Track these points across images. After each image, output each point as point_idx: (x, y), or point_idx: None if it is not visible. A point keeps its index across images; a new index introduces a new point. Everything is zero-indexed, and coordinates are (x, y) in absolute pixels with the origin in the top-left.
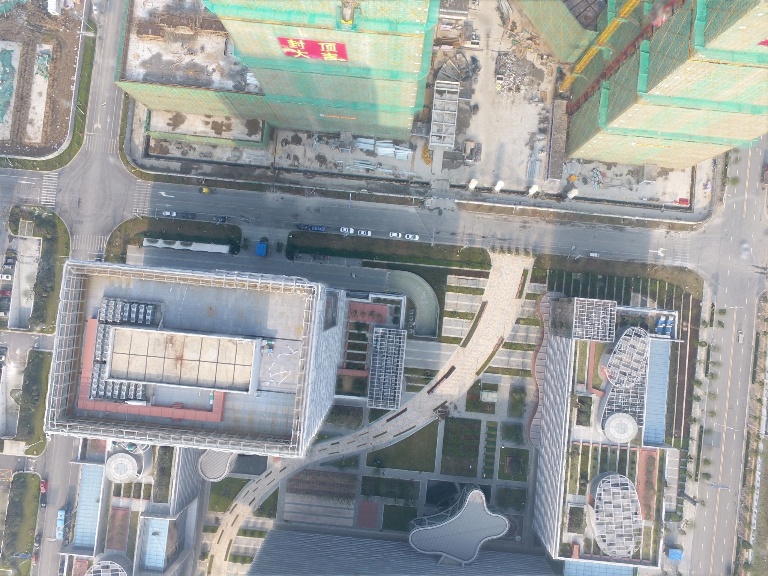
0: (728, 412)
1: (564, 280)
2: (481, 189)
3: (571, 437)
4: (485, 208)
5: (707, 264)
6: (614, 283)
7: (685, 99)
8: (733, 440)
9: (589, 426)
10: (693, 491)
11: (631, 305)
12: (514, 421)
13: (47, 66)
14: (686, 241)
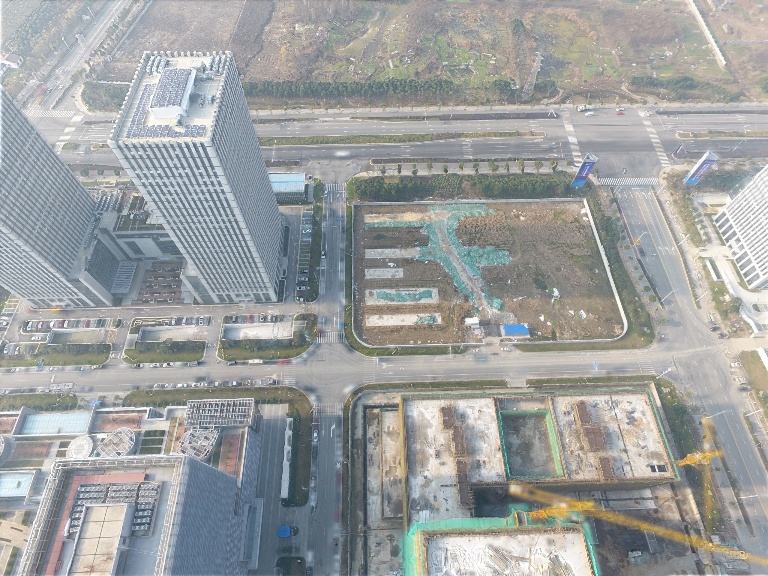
0: None
1: None
2: None
3: None
4: None
5: None
6: None
7: None
8: None
9: None
10: None
11: None
12: None
13: (425, 323)
14: None
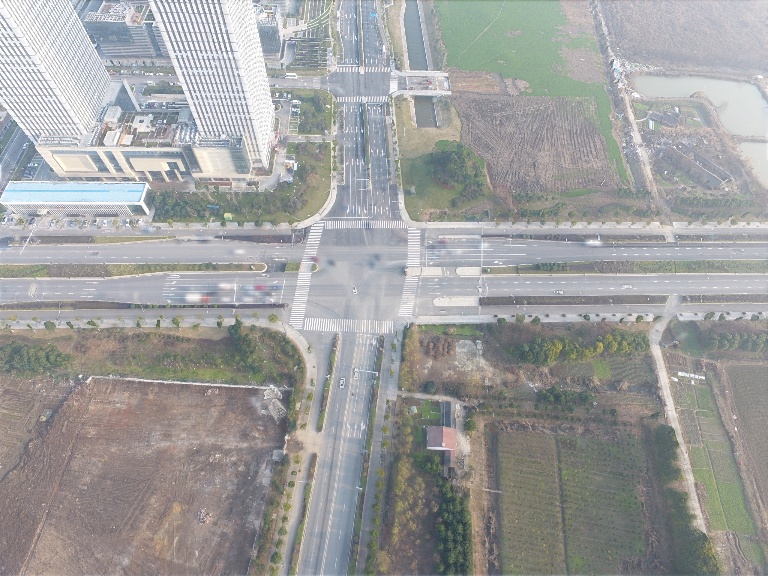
0: None
1: None
2: None
3: None
4: None
5: None
6: None
7: None
8: None
9: None
10: None
11: None
12: None
13: None
14: None
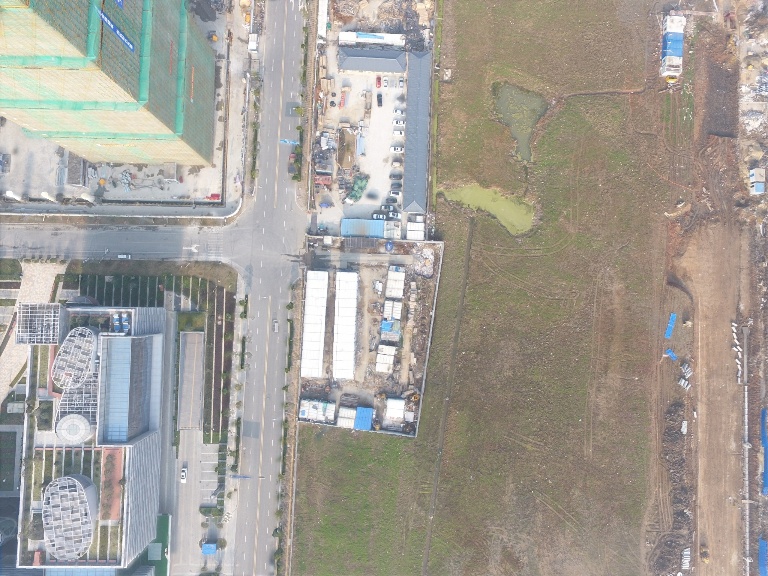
0: (266, 401)
1: (96, 284)
2: (9, 200)
3: (34, 443)
4: (15, 218)
5: (241, 257)
6: (147, 283)
7: (5, 100)
8: (272, 429)
9: (51, 430)
10: (234, 483)
11: (165, 303)
12: None
13: None
14: (219, 236)
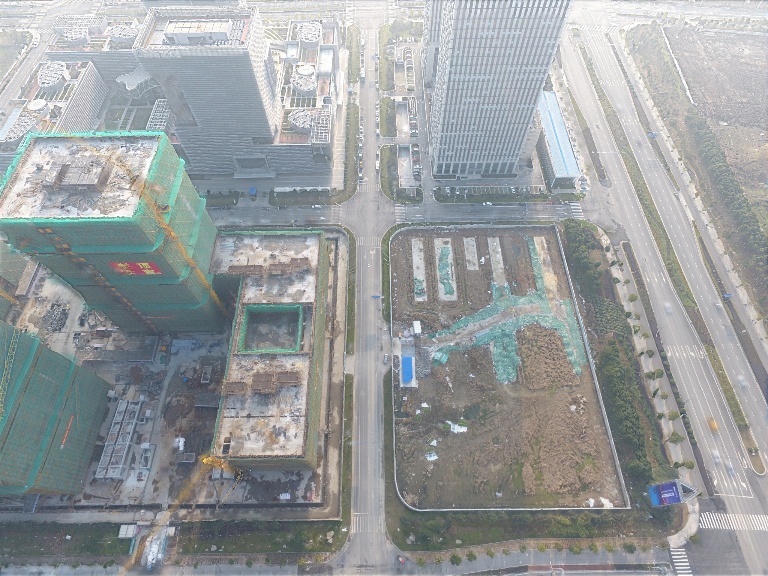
0: None
1: None
2: None
3: None
4: None
5: None
6: None
7: None
8: None
9: None
10: None
11: None
12: (109, 131)
13: None
14: None
